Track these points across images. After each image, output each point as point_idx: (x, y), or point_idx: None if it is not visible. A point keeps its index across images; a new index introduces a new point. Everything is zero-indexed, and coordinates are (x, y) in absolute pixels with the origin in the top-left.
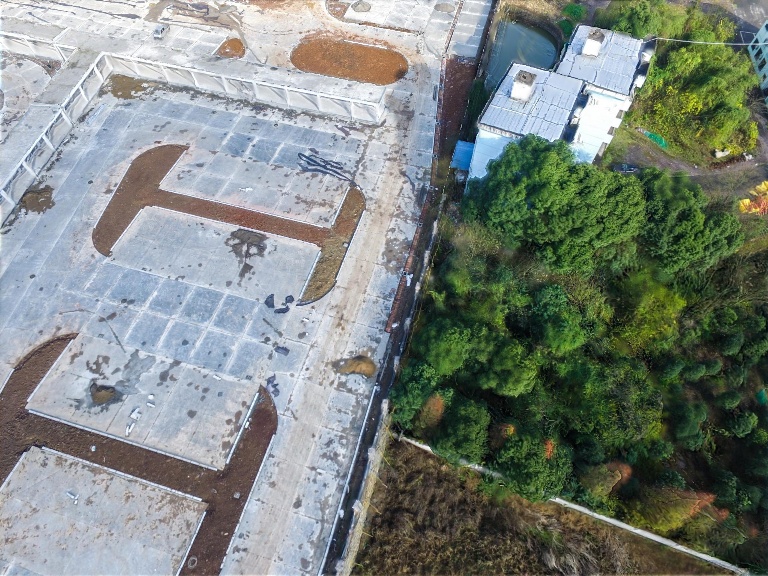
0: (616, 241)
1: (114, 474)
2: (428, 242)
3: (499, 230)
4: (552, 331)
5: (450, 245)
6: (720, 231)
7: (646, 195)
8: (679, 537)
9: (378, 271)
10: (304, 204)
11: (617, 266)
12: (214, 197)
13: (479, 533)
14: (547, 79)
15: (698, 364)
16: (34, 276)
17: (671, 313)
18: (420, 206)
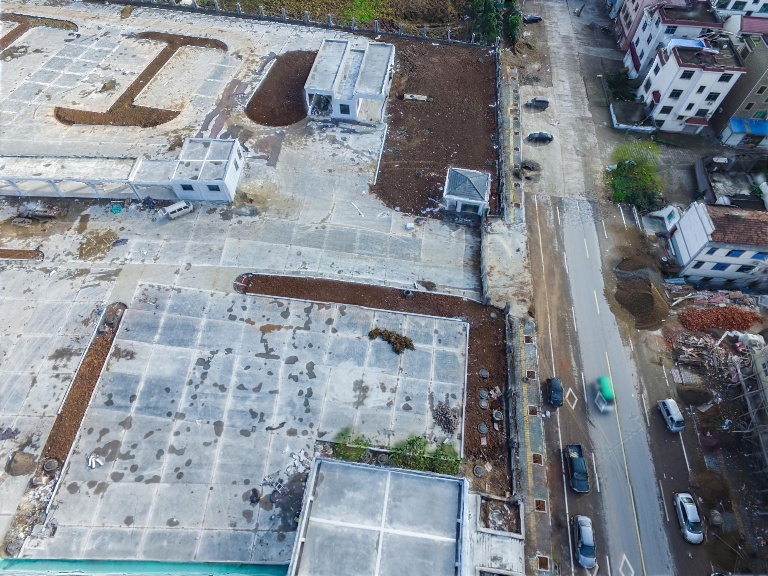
0: None
1: (159, 74)
2: None
3: None
4: None
5: None
6: None
7: None
8: None
9: (66, 8)
10: None
11: None
12: None
13: None
14: None
15: None
16: None
17: None
18: None
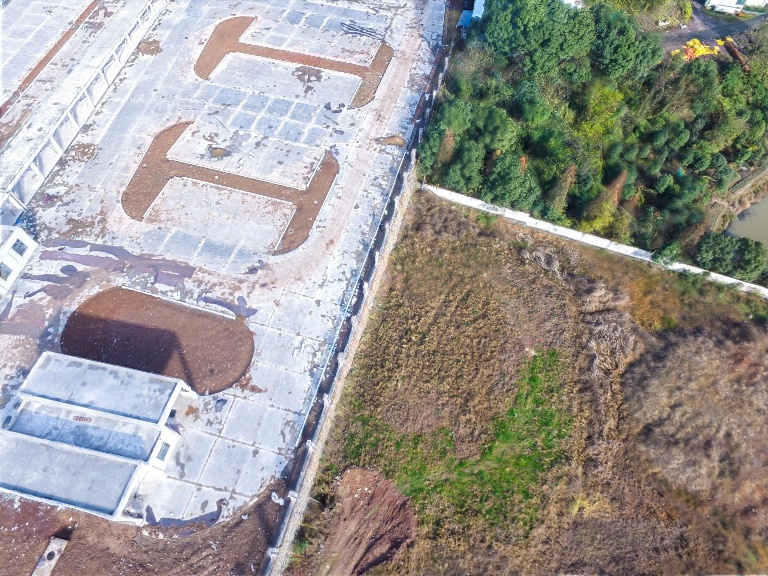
0: (575, 56)
1: (232, 190)
2: None
3: (493, 50)
4: (528, 106)
5: None
6: (647, 44)
7: (595, 18)
8: (612, 236)
9: (405, 91)
10: (348, 52)
11: (576, 77)
12: (280, 47)
13: (478, 236)
14: None
15: (634, 147)
16: (156, 90)
17: (612, 102)
18: (434, 55)
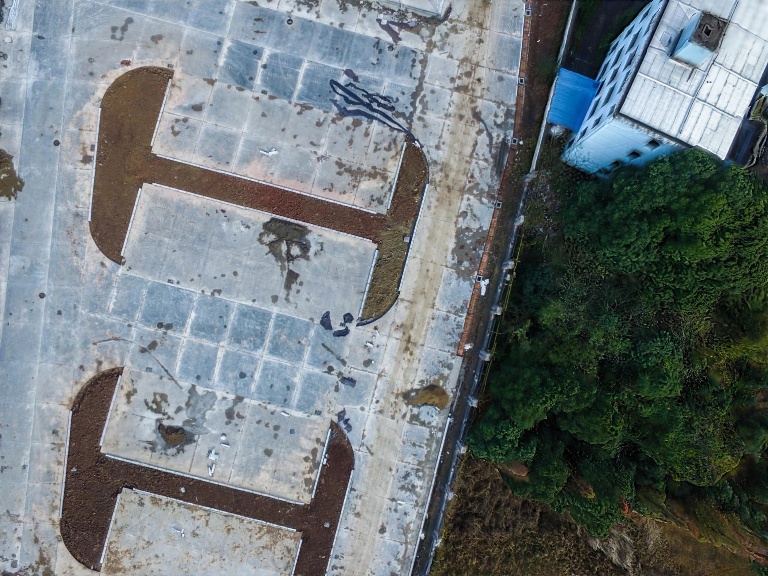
0: None
1: (210, 511)
2: (509, 236)
3: None
4: (649, 386)
5: (532, 229)
6: None
7: None
8: None
9: (447, 277)
10: (349, 175)
11: None
12: (229, 167)
13: (538, 530)
14: (735, 8)
15: None
16: (44, 295)
17: None
18: (499, 175)
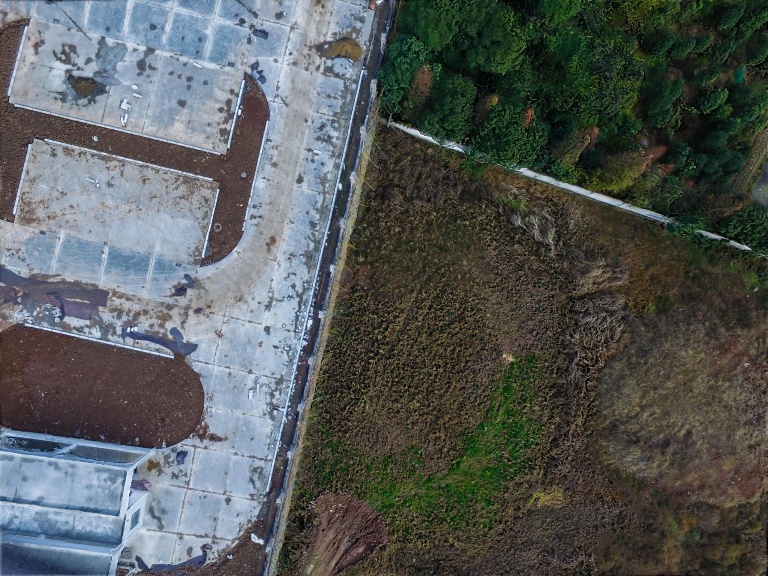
0: None
1: (124, 161)
2: None
3: None
4: None
5: None
6: None
7: None
8: (627, 197)
9: None
10: None
11: None
12: None
13: (459, 201)
14: None
15: (690, 39)
16: None
17: None
18: None
